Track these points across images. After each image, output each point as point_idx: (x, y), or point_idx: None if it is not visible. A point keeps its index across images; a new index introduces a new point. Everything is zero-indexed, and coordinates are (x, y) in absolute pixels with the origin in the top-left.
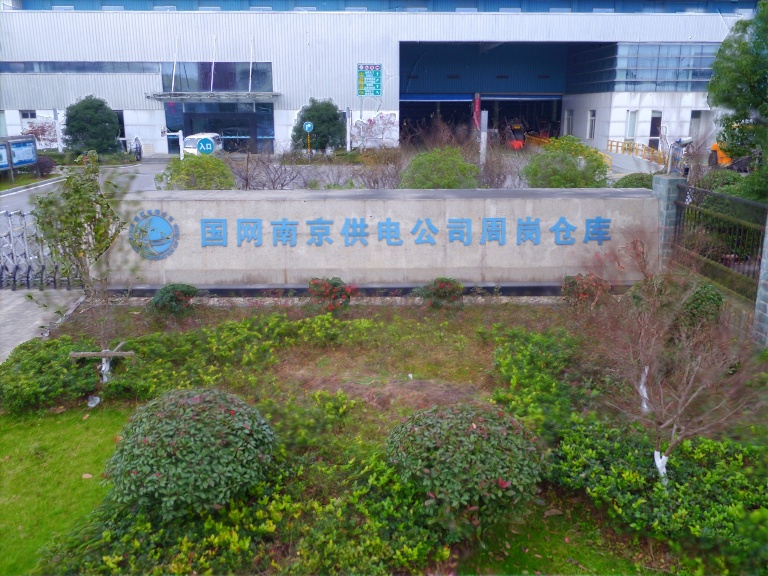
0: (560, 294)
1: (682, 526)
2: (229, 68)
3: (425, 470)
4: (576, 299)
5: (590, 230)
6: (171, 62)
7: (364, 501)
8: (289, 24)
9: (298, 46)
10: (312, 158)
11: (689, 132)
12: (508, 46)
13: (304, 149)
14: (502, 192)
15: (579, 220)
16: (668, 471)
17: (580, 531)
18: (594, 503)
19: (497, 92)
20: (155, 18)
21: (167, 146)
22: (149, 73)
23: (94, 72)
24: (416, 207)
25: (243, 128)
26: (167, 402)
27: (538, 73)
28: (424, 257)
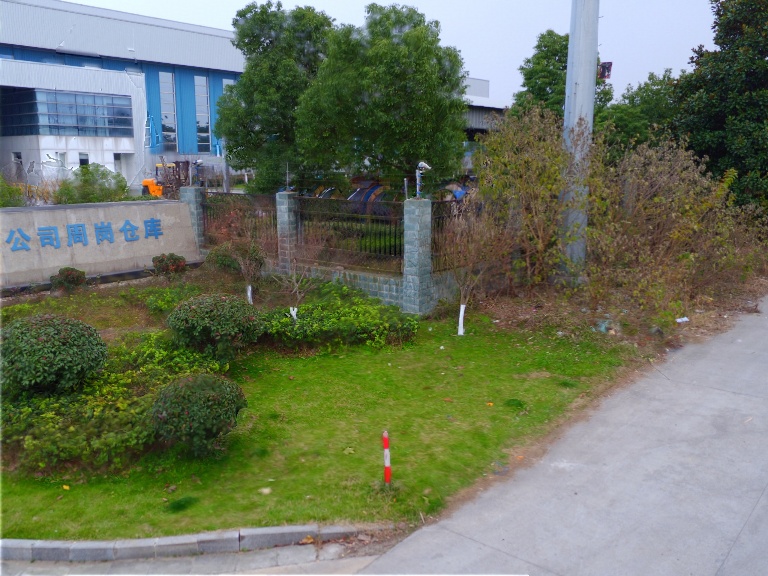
0: (138, 277)
1: (319, 329)
2: None
3: (211, 322)
4: (164, 272)
5: (148, 228)
6: None
7: (163, 363)
8: None
9: None
10: None
11: None
12: None
13: None
14: (67, 206)
15: (139, 221)
16: (298, 316)
17: (269, 355)
18: (274, 337)
19: None
20: None
21: None
22: None
23: None
24: (7, 219)
25: None
26: (31, 321)
27: None
28: (22, 261)
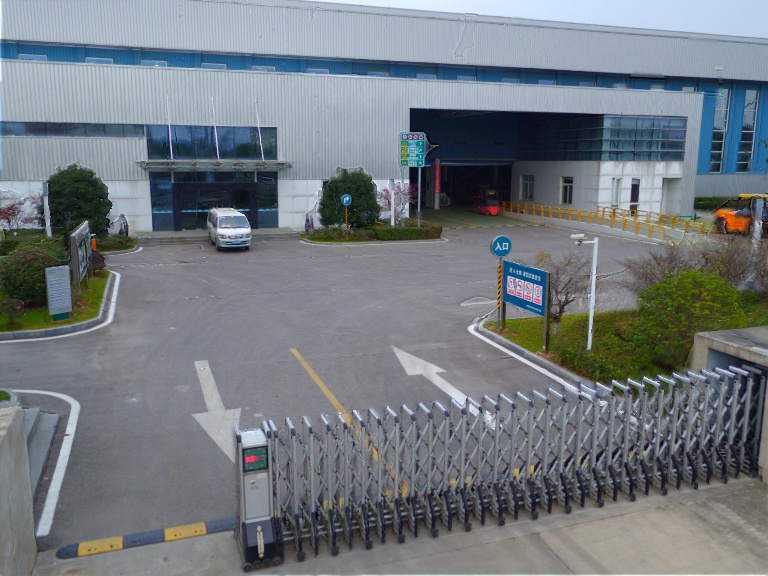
0: None
1: None
2: (227, 133)
3: None
4: None
5: None
6: (159, 125)
7: None
8: (296, 86)
9: (306, 110)
10: (347, 234)
11: (662, 198)
12: (466, 113)
13: (337, 224)
14: None
15: None
16: None
17: None
18: None
19: (456, 157)
20: (141, 74)
21: (151, 222)
22: (131, 137)
23: (59, 135)
24: None
25: (228, 199)
26: None
27: (493, 139)
28: None
